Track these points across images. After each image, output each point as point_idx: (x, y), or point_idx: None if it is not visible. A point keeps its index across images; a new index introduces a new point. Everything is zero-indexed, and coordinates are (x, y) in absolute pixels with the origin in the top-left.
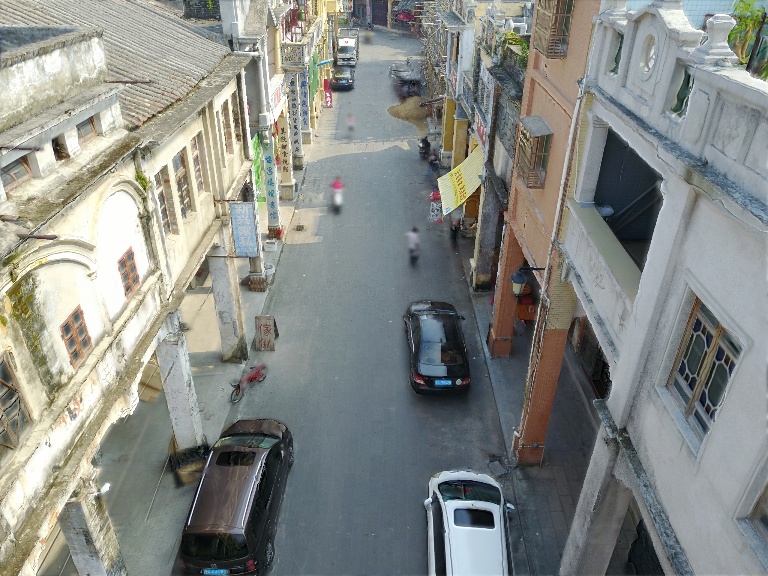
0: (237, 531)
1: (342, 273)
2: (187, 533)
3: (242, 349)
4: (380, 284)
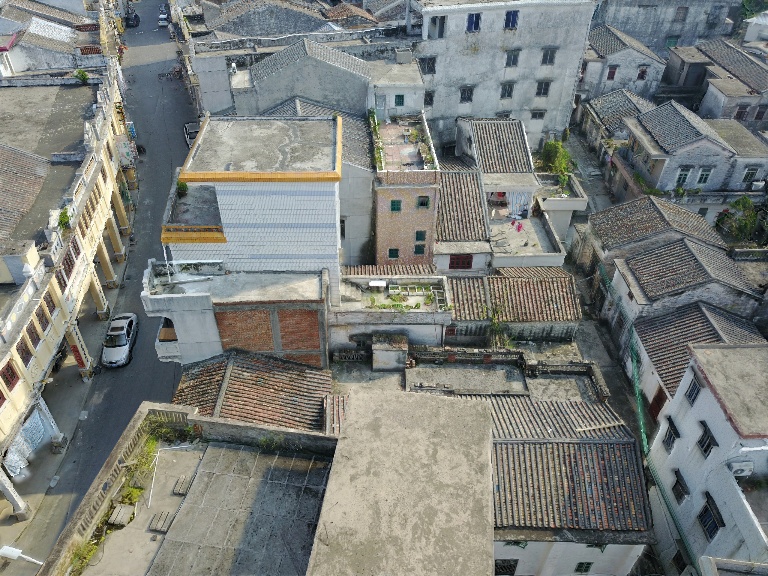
0: (133, 17)
1: (148, 5)
2: (126, 17)
3: (128, 12)
4: (156, 6)
